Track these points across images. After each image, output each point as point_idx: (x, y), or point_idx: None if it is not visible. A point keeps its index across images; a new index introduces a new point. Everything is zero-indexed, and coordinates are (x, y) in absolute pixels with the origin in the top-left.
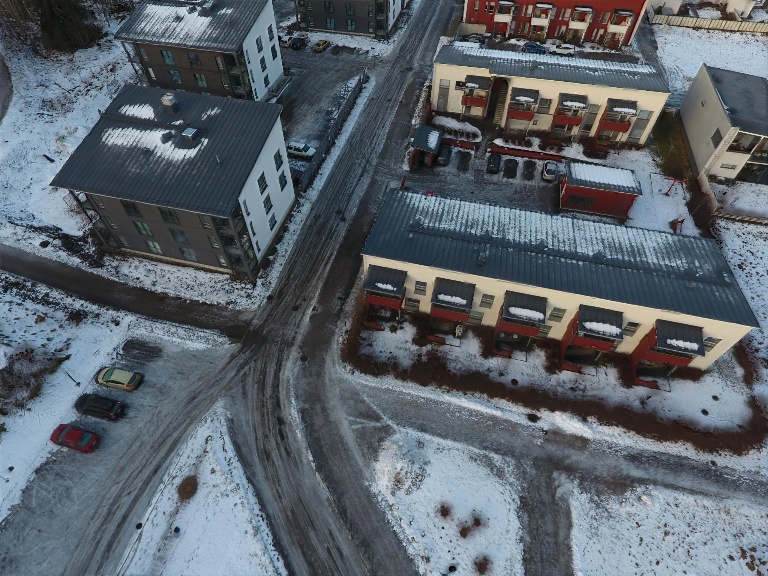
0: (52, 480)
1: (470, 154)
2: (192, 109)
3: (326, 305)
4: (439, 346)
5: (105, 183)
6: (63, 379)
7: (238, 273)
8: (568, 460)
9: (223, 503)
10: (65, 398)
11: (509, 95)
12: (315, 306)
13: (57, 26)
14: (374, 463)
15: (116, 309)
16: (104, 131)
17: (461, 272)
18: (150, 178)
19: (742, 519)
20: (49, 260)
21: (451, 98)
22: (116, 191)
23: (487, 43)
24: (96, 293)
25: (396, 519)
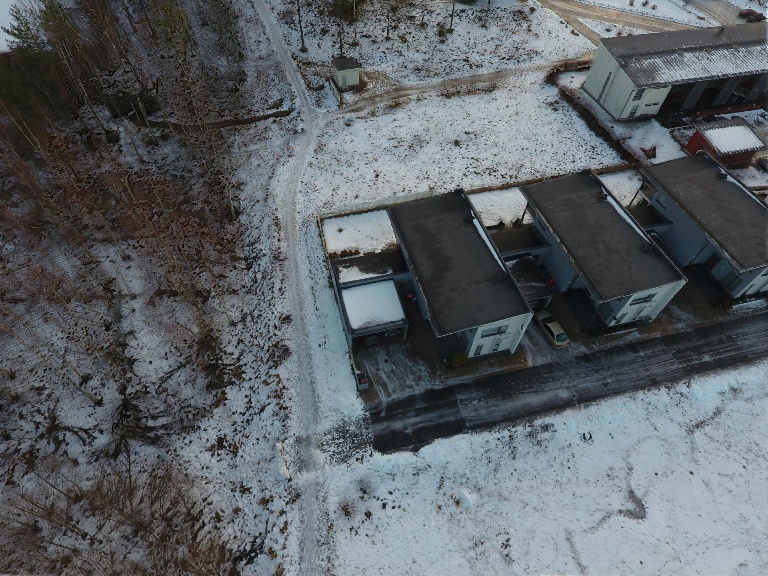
0: None
1: None
2: None
3: None
4: None
5: None
6: None
7: None
8: None
9: None
10: None
11: None
12: None
13: None
14: None
15: None
16: None
17: None
18: None
19: (543, 60)
20: None
21: None
22: None
23: None
24: None
25: None
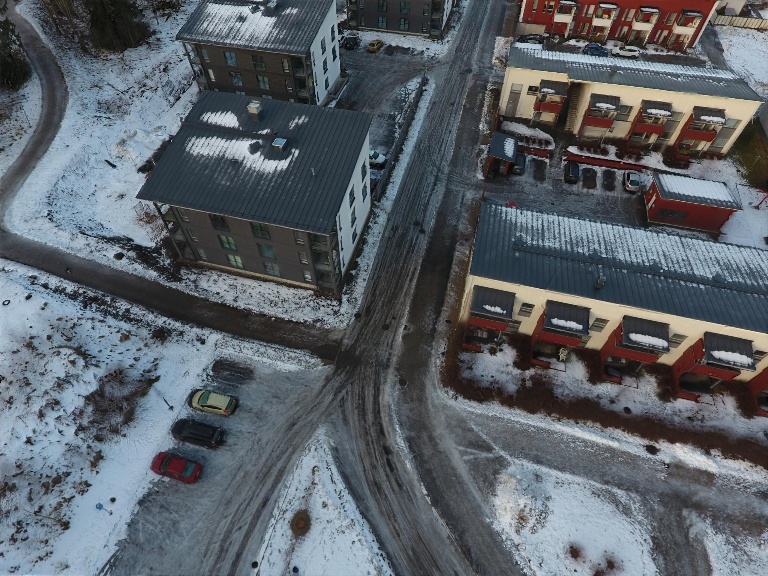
0: (157, 513)
1: (545, 162)
2: (278, 117)
3: (418, 324)
4: (543, 370)
5: (195, 196)
6: (155, 402)
7: (322, 289)
8: (696, 497)
9: (340, 541)
10: (160, 423)
11: (587, 101)
12: (406, 325)
13: (108, 24)
14: (492, 498)
15: (200, 326)
16: (187, 140)
17: (580, 296)
18: (242, 191)
19: None
20: (125, 273)
21: (521, 103)
22: (207, 205)
23: (545, 44)
24: (177, 309)
25: (525, 560)
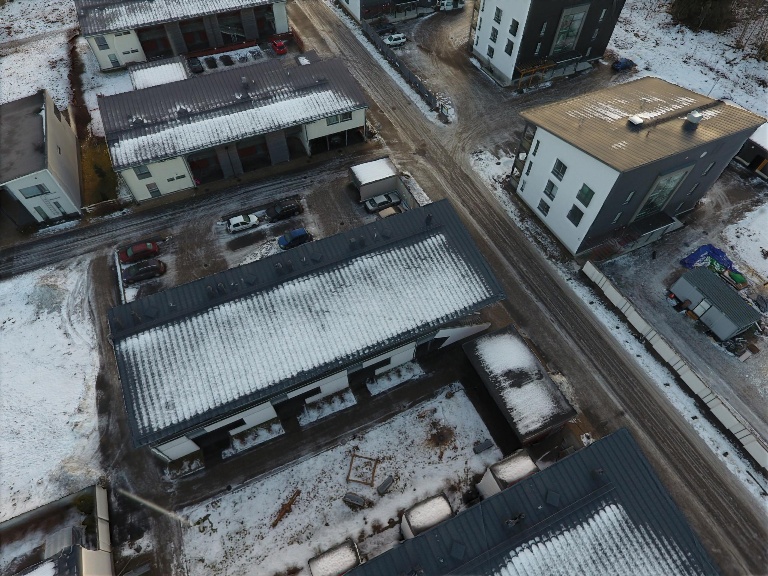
0: None
1: None
2: None
3: (291, 4)
4: None
5: None
6: None
7: None
8: None
9: None
10: None
11: None
12: (296, 3)
13: None
14: None
15: None
16: None
17: None
18: None
19: None
20: None
21: None
22: None
23: None
24: None
25: None
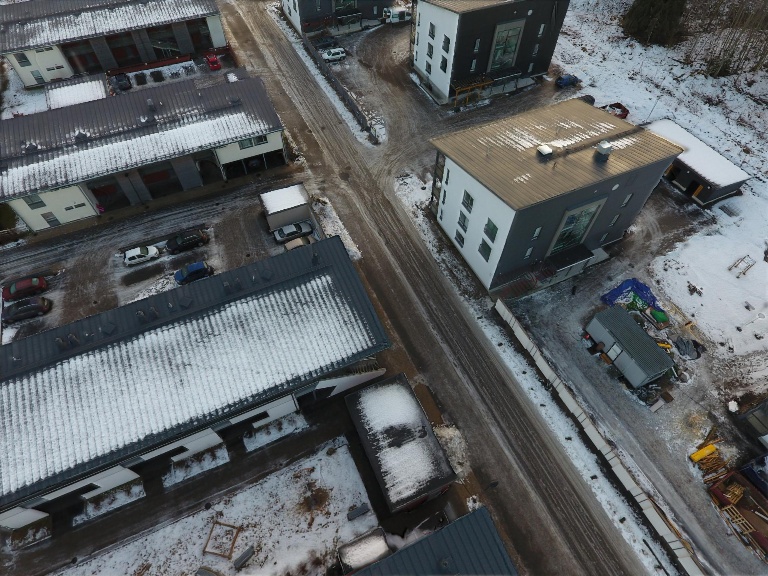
0: None
1: None
2: None
3: (235, 16)
4: None
5: None
6: None
7: None
8: None
9: None
10: None
11: None
12: None
13: None
14: None
15: None
16: None
17: None
18: None
19: None
20: None
21: None
22: None
23: None
24: None
25: None
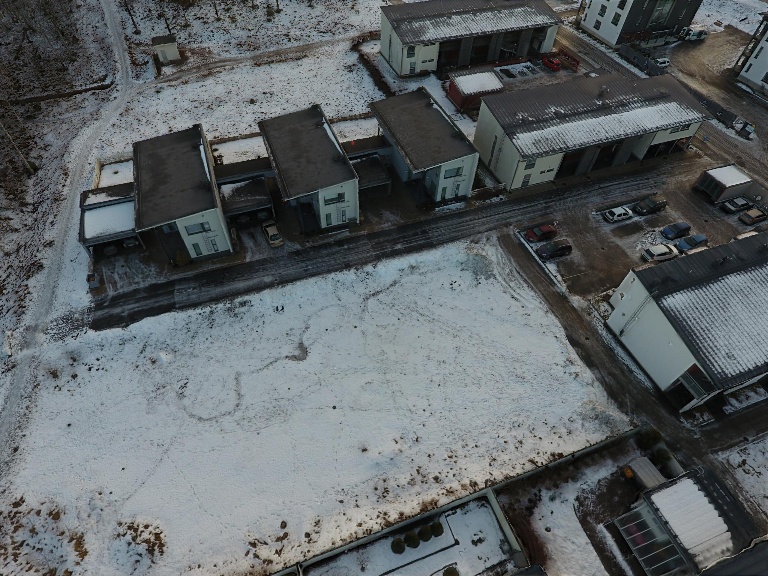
0: None
1: None
2: None
3: None
4: None
5: None
6: None
7: None
8: None
9: None
10: None
11: None
12: None
13: None
14: None
15: None
16: None
17: None
18: None
19: (356, 32)
20: None
21: None
22: None
23: None
24: None
25: None
